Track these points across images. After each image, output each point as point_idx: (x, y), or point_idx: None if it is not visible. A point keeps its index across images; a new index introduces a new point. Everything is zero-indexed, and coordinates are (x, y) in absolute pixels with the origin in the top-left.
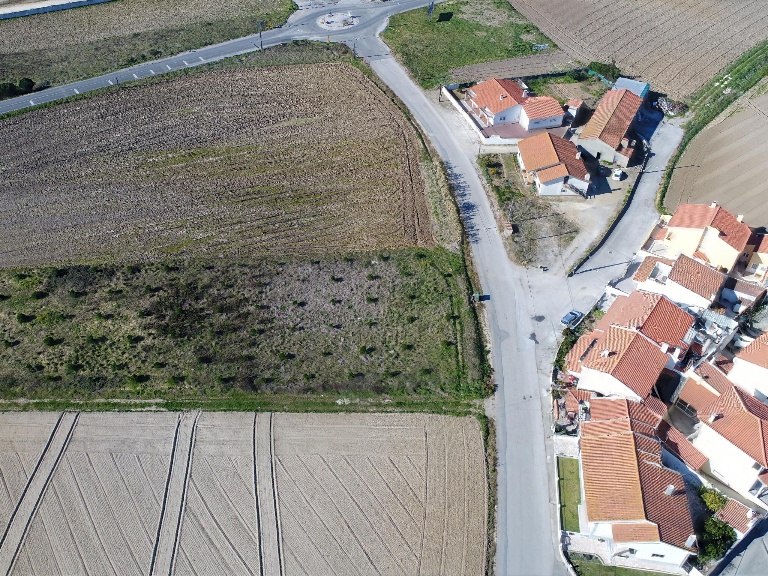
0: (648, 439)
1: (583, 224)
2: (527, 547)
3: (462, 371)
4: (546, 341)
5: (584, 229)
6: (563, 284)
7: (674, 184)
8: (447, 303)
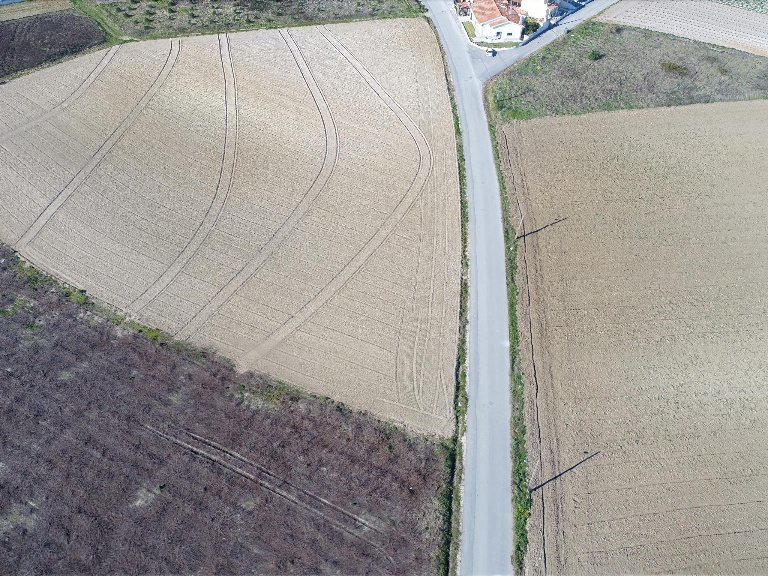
0: (500, 2)
1: None
2: (456, 43)
3: (410, 7)
4: None
5: None
6: None
7: None
8: None
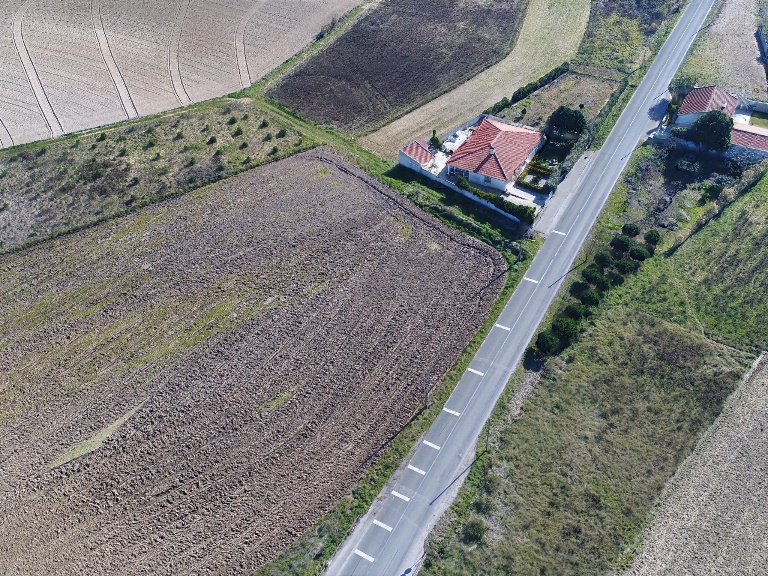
0: None
1: None
2: None
3: None
4: None
5: None
6: None
7: None
8: None
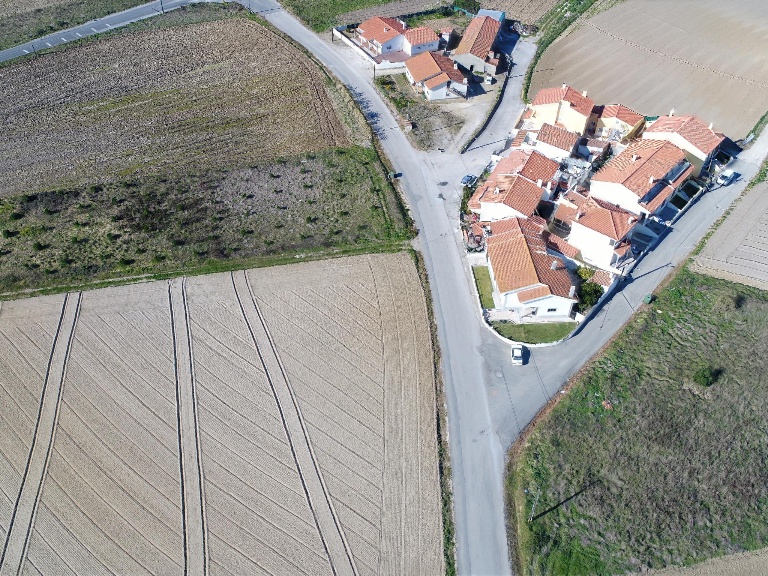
0: (535, 239)
1: (467, 117)
2: (459, 323)
3: (390, 224)
4: (451, 198)
5: (468, 120)
6: (458, 159)
7: (534, 83)
8: (369, 182)
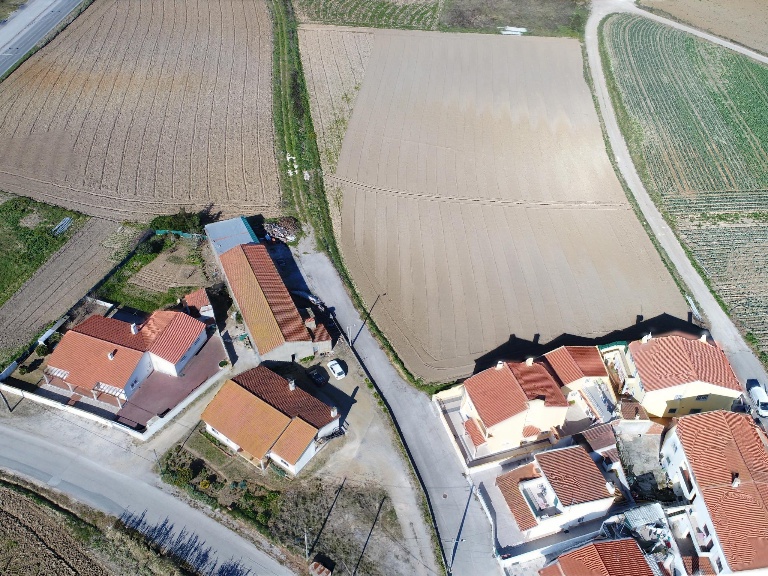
0: None
1: (380, 479)
2: None
3: None
4: None
5: (388, 486)
6: None
7: (392, 338)
8: None
